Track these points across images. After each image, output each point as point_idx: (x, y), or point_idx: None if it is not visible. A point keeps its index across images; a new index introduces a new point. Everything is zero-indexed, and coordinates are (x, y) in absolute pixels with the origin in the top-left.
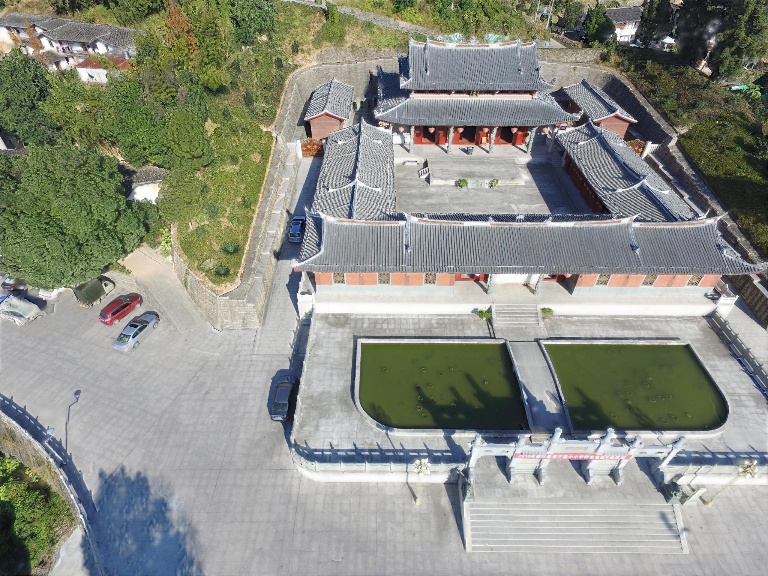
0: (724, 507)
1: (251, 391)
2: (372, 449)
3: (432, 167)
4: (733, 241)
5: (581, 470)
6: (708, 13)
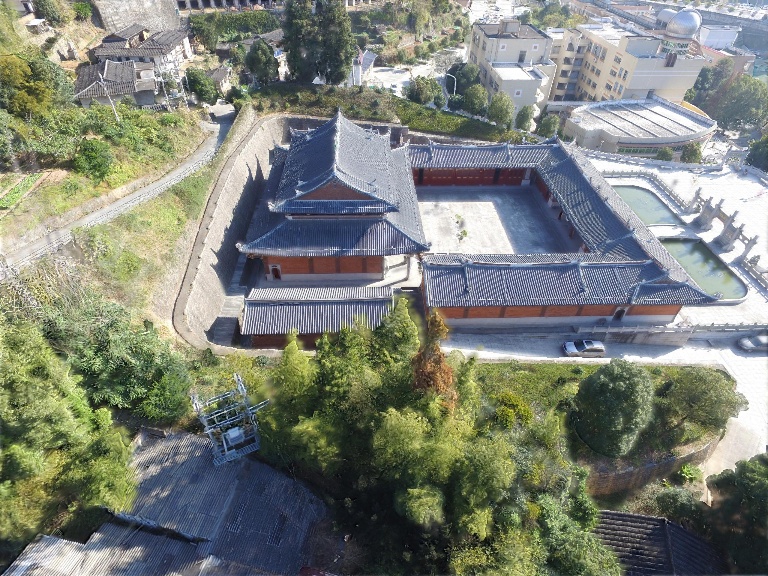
0: None
1: (767, 368)
2: (762, 295)
3: (435, 250)
4: None
5: (706, 230)
6: (313, 43)
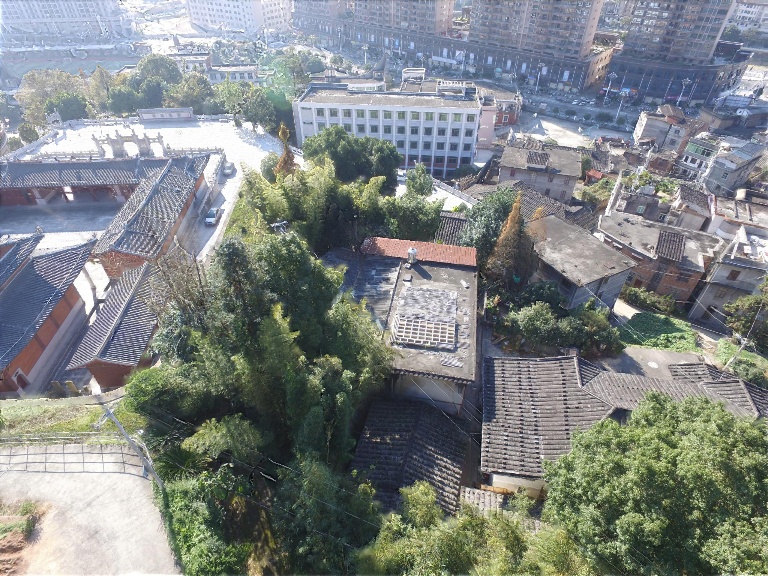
0: None
1: None
2: None
3: None
4: None
5: None
6: None
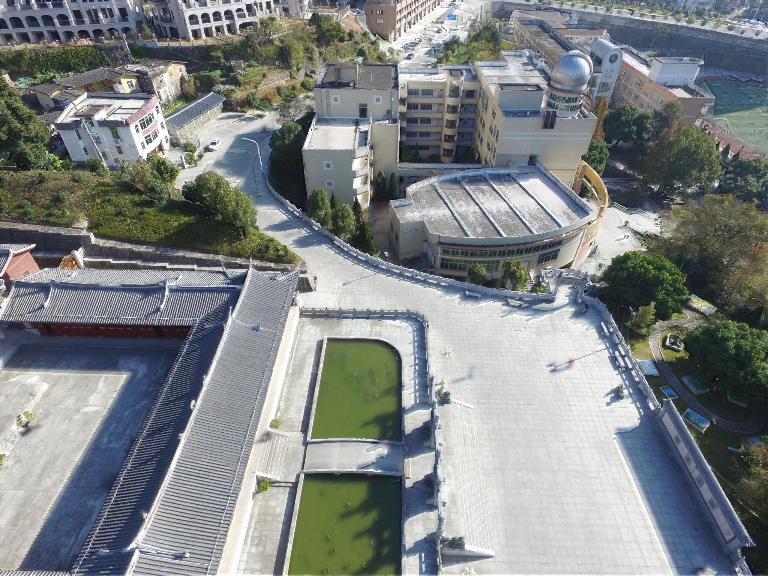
0: (443, 375)
1: None
2: None
3: None
4: (237, 266)
5: (432, 448)
6: None
